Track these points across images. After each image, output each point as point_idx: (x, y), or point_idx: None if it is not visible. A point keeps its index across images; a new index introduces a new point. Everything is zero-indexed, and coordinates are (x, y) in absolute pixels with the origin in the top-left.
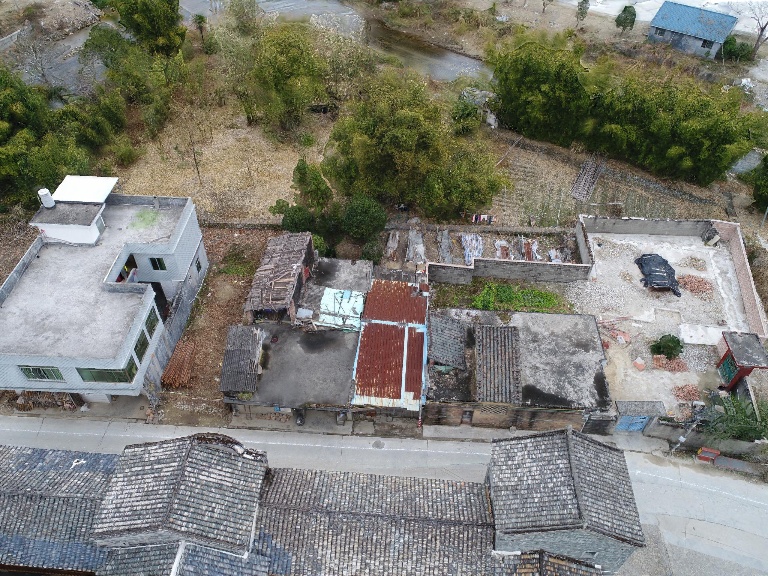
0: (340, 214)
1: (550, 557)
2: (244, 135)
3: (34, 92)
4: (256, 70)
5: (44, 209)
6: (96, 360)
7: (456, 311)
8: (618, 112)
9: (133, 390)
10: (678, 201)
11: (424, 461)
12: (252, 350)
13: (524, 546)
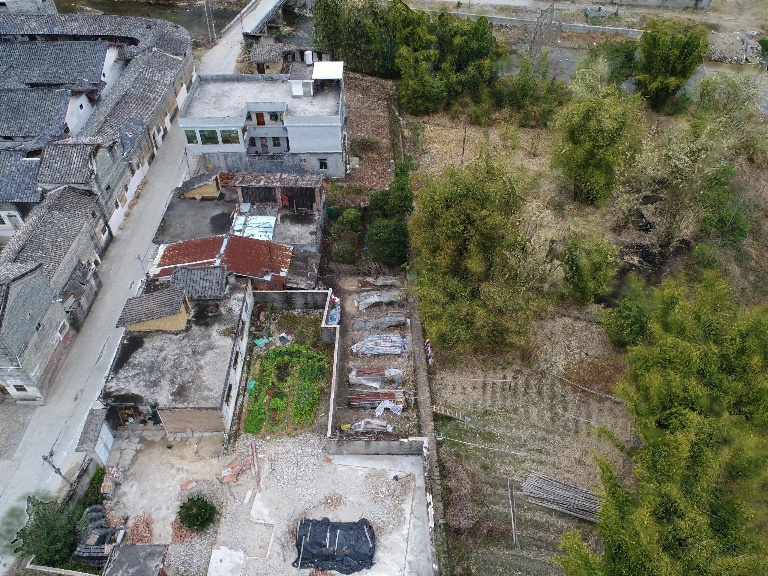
0: None
1: None
2: (554, 175)
3: (488, 40)
4: None
5: None
6: None
7: (240, 296)
8: None
9: None
10: None
11: None
12: (202, 181)
13: None
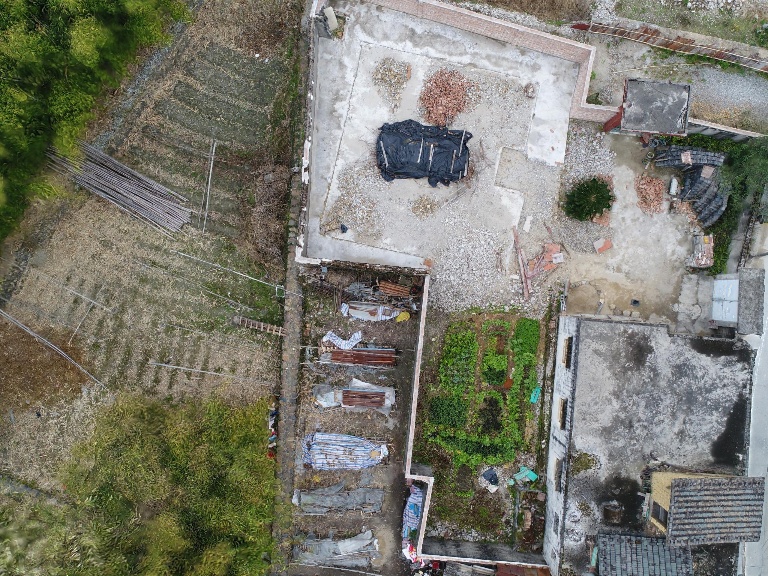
0: None
1: None
2: None
3: None
4: None
5: None
6: None
7: (570, 540)
8: None
9: None
10: (193, 29)
11: (753, 572)
12: None
13: None
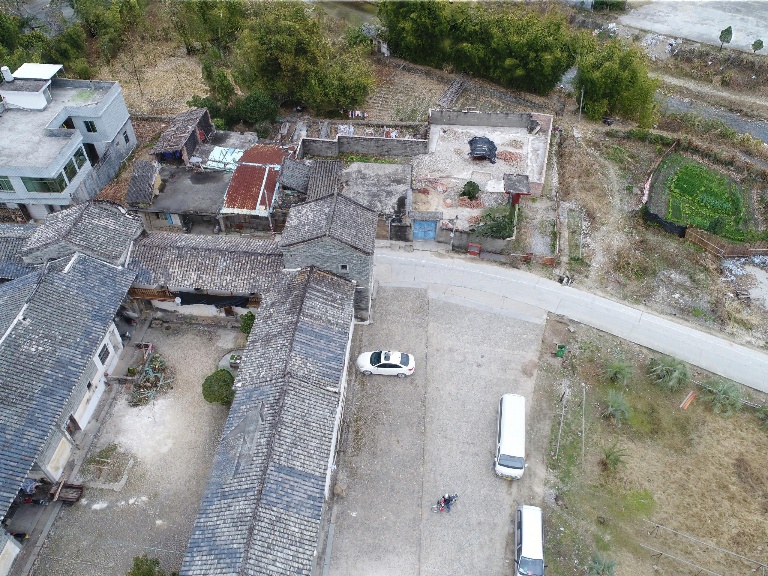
0: (241, 106)
1: (318, 270)
2: (183, 62)
3: None
4: (186, 3)
5: (6, 83)
6: (34, 169)
7: (310, 161)
8: (471, 34)
9: (63, 199)
10: (522, 108)
11: None
12: (150, 176)
13: (301, 262)
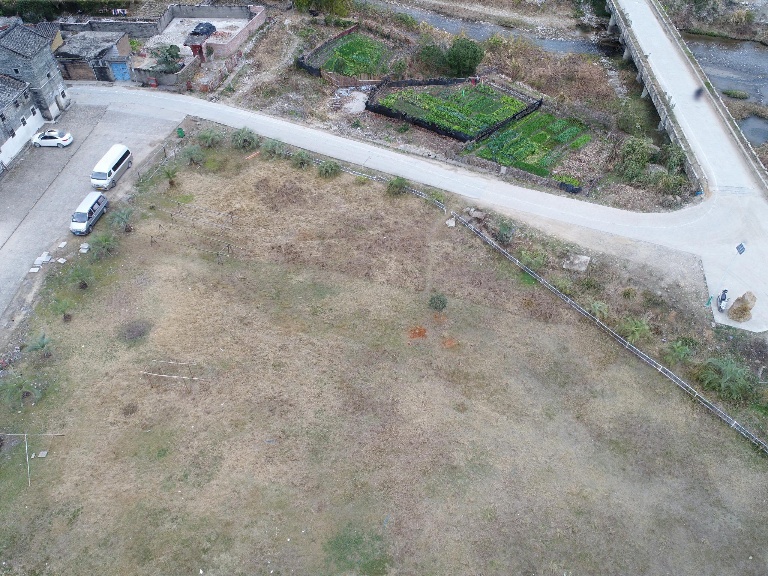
0: None
1: None
2: None
3: None
4: None
5: None
6: None
7: None
8: None
9: None
10: None
11: None
12: None
13: None
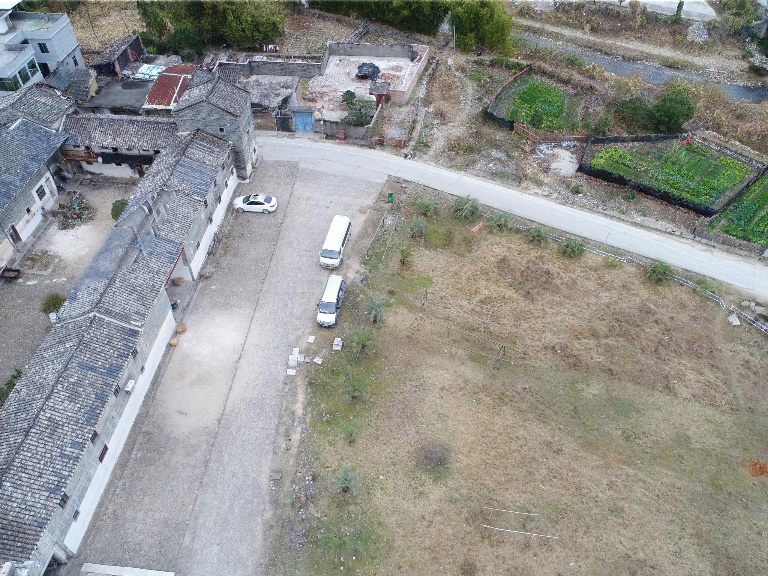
0: None
1: (203, 133)
2: (133, 13)
3: None
4: None
5: None
6: None
7: None
8: None
9: None
10: None
11: None
12: (88, 80)
13: (189, 126)
